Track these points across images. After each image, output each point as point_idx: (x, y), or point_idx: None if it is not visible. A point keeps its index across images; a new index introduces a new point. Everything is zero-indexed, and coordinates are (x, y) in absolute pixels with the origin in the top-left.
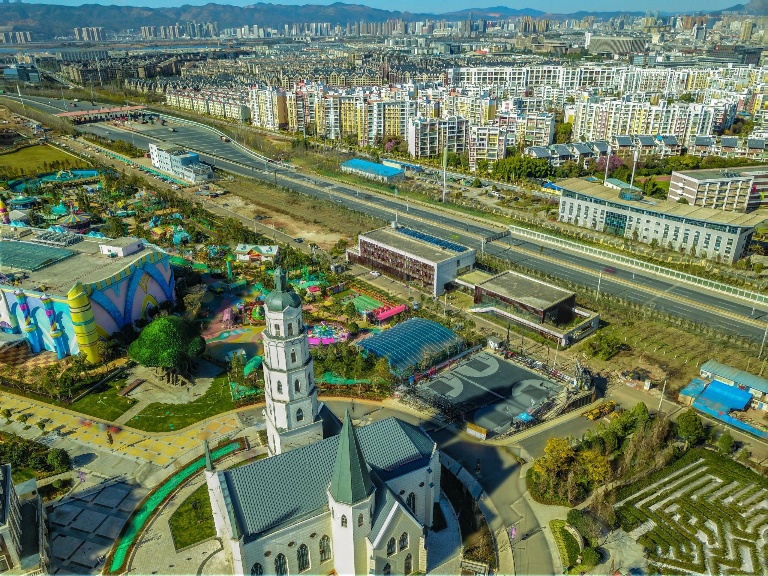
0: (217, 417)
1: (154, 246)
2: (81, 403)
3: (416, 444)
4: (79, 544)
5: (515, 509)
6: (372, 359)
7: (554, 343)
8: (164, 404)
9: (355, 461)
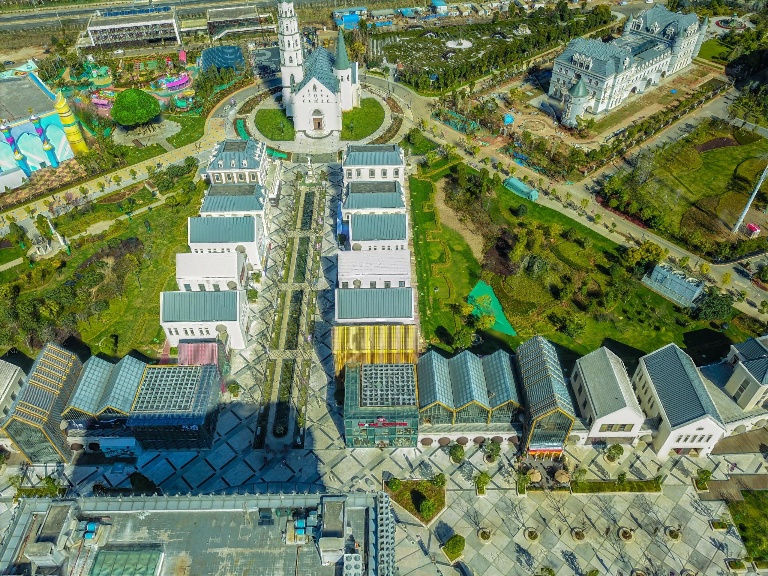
0: (208, 123)
1: (1, 77)
2: (132, 160)
3: None
4: None
5: None
6: (226, 70)
7: (271, 33)
8: (173, 136)
9: None
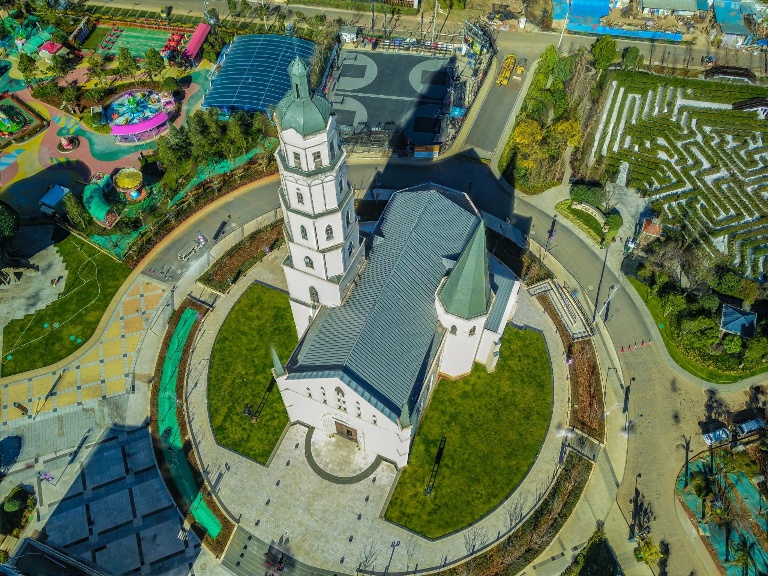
0: (123, 293)
1: None
2: None
3: (463, 207)
4: (135, 541)
5: (520, 213)
6: (245, 119)
7: (405, 8)
8: (26, 318)
9: (486, 270)
